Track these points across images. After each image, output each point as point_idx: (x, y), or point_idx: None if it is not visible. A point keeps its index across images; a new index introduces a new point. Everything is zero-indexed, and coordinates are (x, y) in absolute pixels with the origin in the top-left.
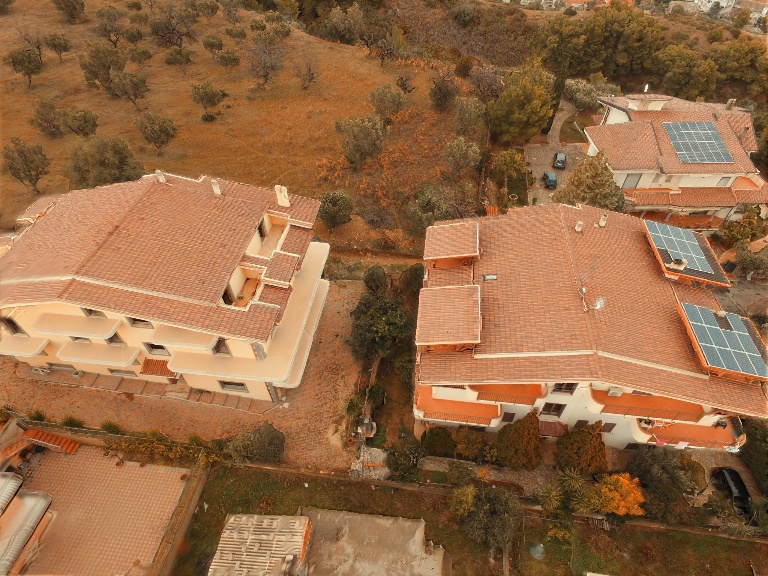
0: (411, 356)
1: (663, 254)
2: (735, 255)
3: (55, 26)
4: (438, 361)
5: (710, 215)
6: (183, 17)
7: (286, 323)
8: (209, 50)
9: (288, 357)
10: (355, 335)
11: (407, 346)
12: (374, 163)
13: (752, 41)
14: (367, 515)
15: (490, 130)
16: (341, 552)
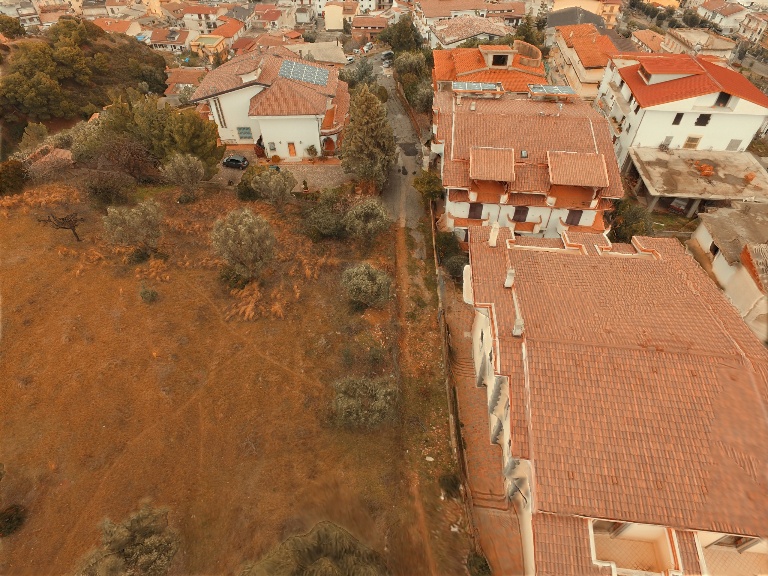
0: None
1: (487, 90)
2: None
3: None
4: None
5: None
6: None
7: None
8: None
9: None
10: None
11: None
12: None
13: None
14: (714, 233)
15: None
16: (743, 242)
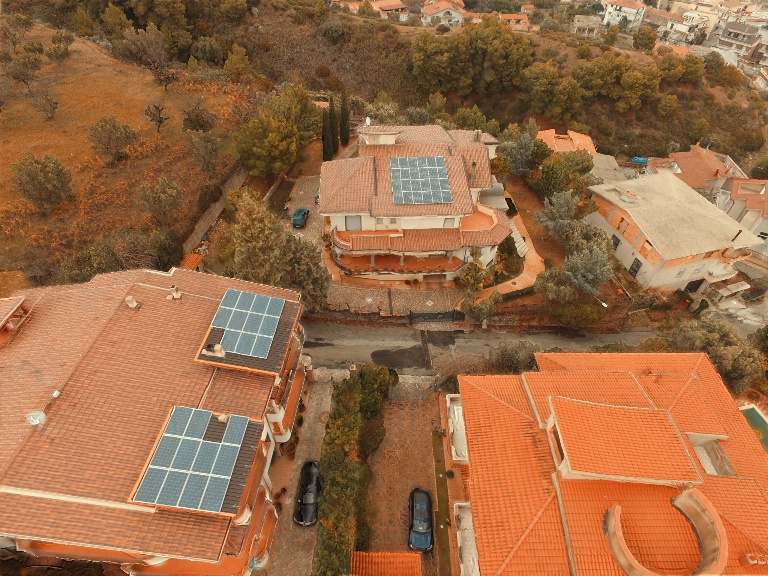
0: None
1: (214, 335)
2: (461, 303)
3: None
4: None
5: (448, 257)
6: None
7: None
8: None
9: None
10: None
11: None
12: (74, 206)
13: (618, 58)
14: None
15: (242, 164)
16: None
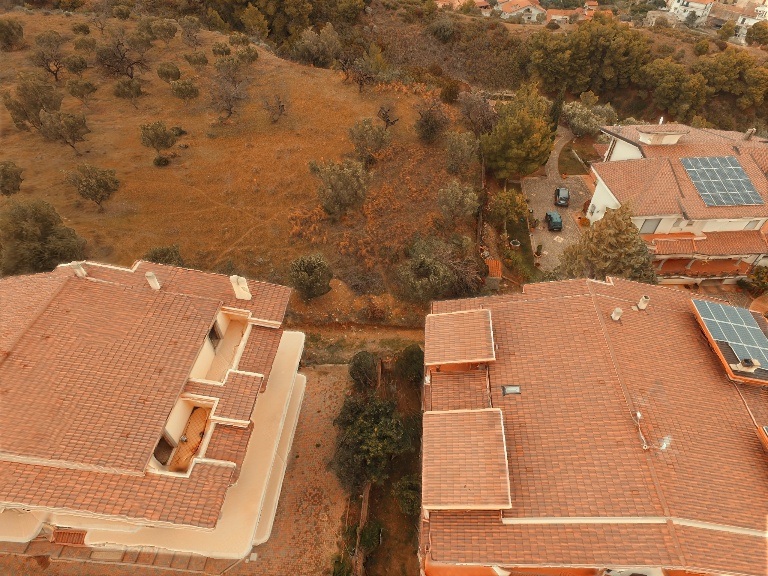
0: (412, 479)
1: (724, 349)
2: None
3: None
4: (454, 526)
5: (736, 260)
6: (136, 42)
7: (249, 459)
8: (164, 80)
9: (251, 516)
10: (340, 458)
11: (405, 457)
12: (356, 212)
13: (739, 53)
14: None
15: (484, 166)
16: None
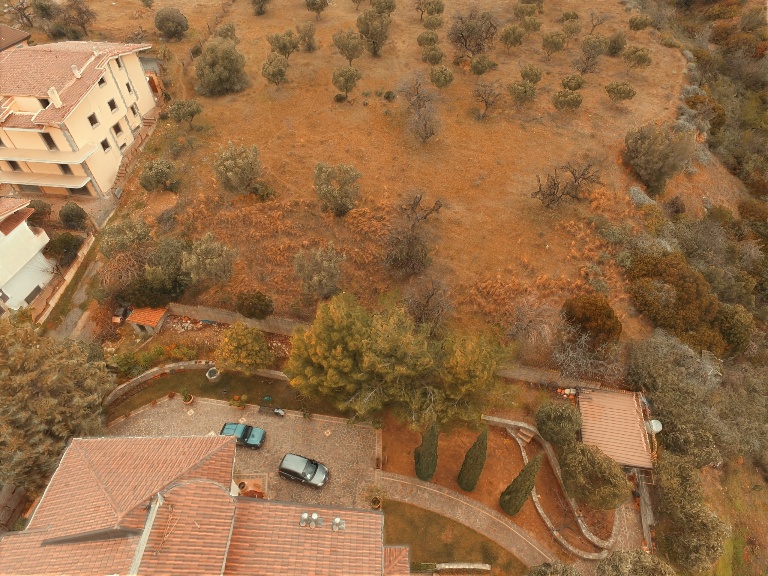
0: None
1: None
2: None
3: (507, 6)
4: None
5: None
6: (543, 39)
7: (6, 151)
8: None
9: None
10: None
11: None
12: None
13: None
14: None
15: None
16: None
